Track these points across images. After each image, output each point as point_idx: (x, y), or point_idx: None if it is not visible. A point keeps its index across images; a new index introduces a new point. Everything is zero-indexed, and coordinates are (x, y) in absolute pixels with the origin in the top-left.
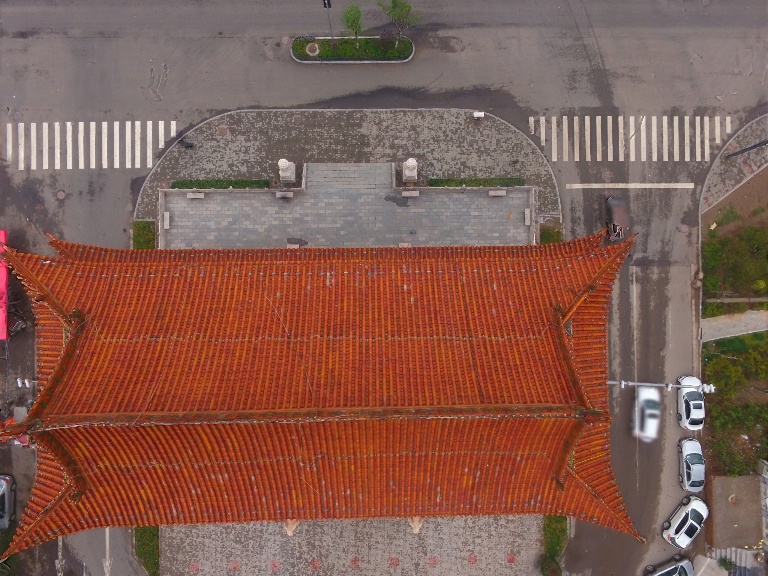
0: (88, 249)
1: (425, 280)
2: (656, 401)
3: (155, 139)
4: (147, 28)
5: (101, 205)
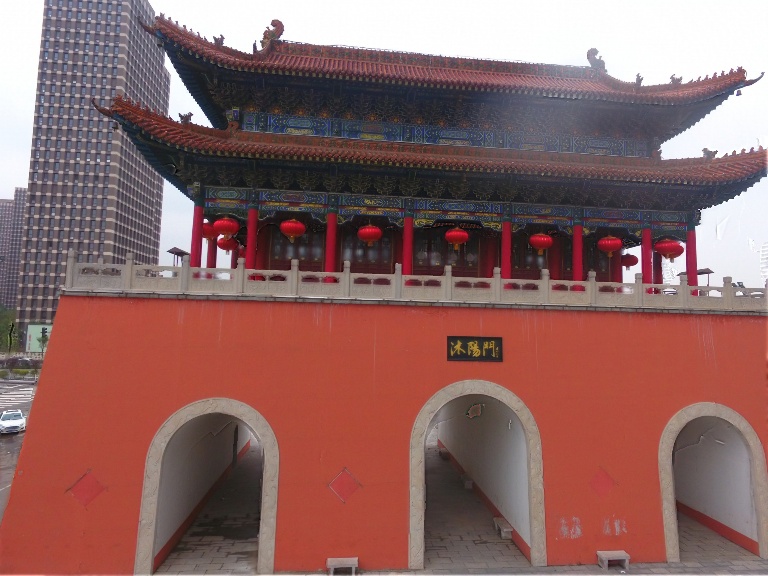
0: None
1: None
2: None
3: None
4: None
5: None
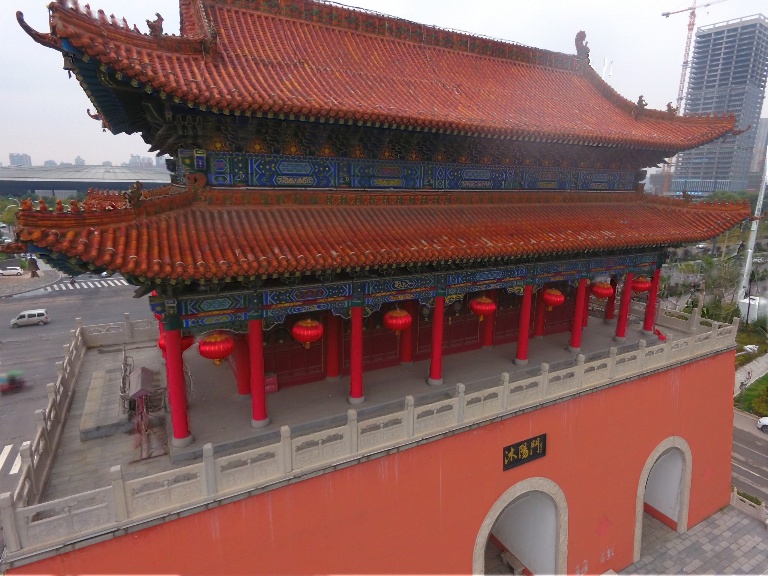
0: None
1: None
2: None
3: None
4: None
5: None
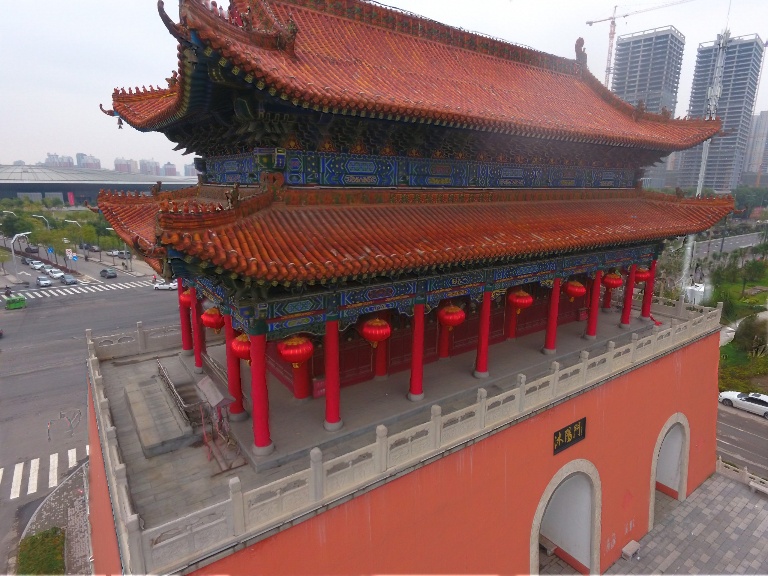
0: None
1: None
2: (739, 420)
3: (62, 463)
4: (53, 406)
5: None
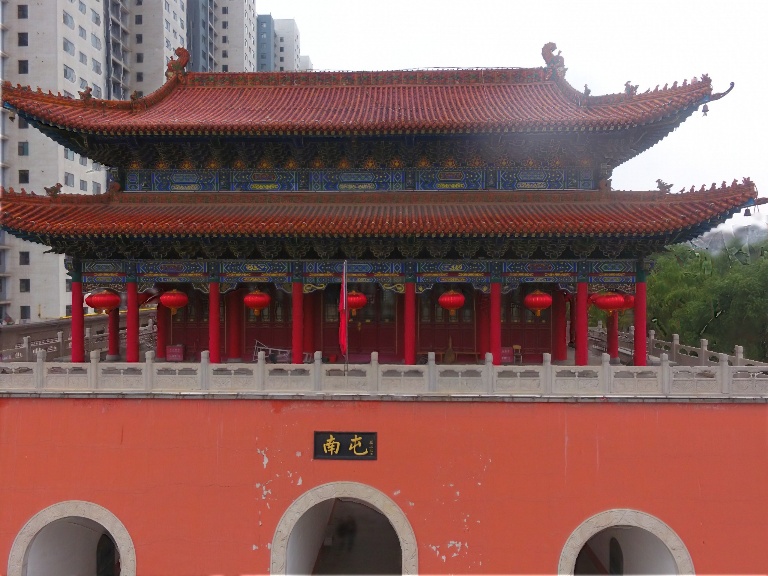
0: (706, 209)
1: None
2: None
3: None
4: None
5: None
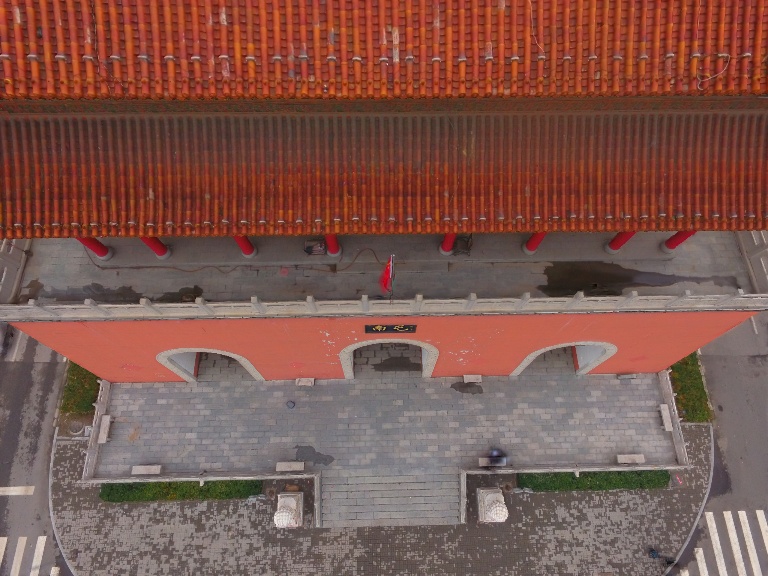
0: None
1: (178, 38)
2: None
3: (713, 565)
4: None
5: (765, 447)
